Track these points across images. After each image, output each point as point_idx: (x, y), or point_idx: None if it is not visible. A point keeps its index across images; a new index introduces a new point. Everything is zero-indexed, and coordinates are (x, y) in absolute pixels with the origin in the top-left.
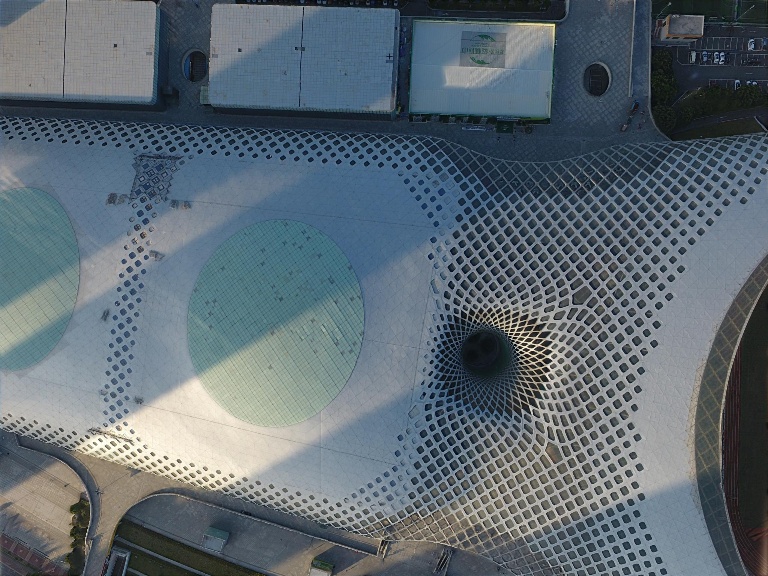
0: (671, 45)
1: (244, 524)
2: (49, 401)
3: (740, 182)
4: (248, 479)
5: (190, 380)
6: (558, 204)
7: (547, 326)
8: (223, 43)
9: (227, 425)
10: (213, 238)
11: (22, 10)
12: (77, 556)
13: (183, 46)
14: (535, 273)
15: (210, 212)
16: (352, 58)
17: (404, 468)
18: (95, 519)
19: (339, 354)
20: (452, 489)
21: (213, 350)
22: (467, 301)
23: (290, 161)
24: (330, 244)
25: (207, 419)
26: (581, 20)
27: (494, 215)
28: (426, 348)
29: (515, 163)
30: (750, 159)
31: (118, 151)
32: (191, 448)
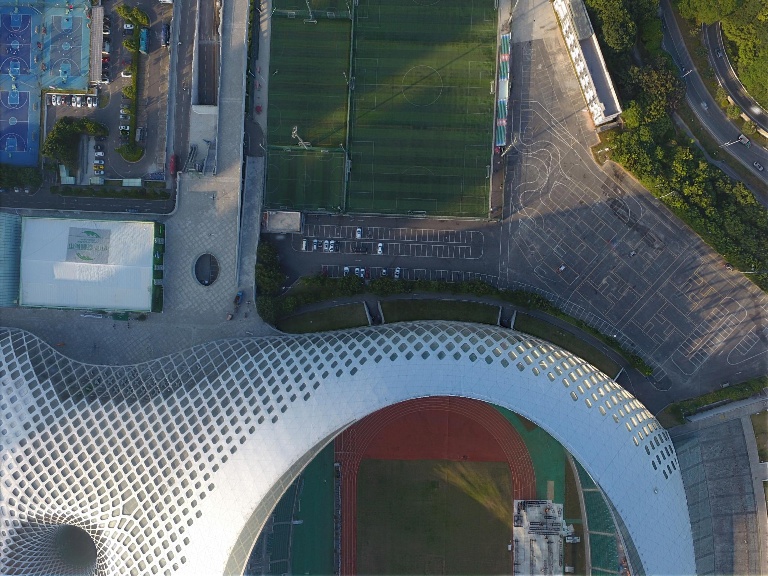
0: (286, 232)
1: None
2: None
3: (279, 398)
4: None
5: None
6: (121, 413)
7: (104, 533)
8: None
9: None
10: None
11: None
12: None
13: None
14: (92, 482)
15: None
16: None
17: None
18: None
19: None
20: None
21: None
22: (31, 507)
23: None
24: None
25: None
26: (190, 213)
27: (61, 423)
28: None
29: (93, 367)
30: (298, 371)
31: None
32: None
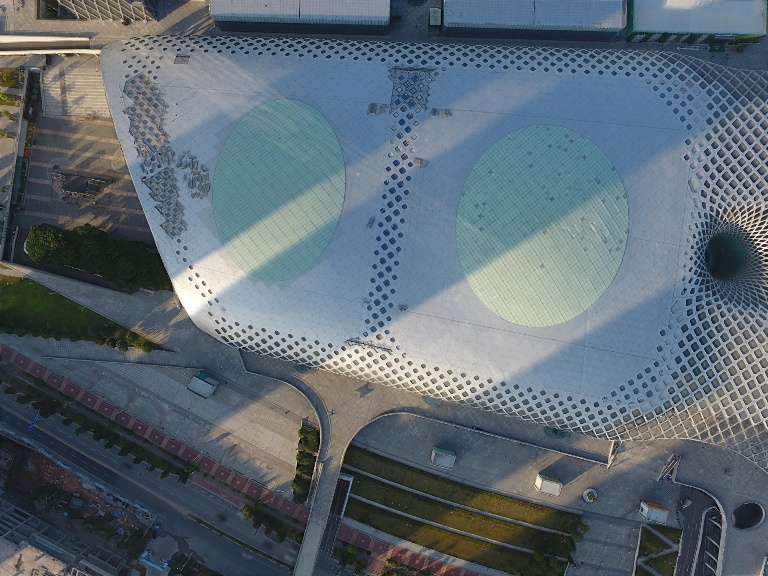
0: None
1: (468, 443)
2: (309, 312)
3: None
4: (506, 383)
5: (457, 284)
6: None
7: None
8: None
9: (492, 328)
10: (477, 144)
11: None
12: (303, 482)
13: None
14: None
15: (471, 120)
16: None
17: (665, 363)
18: (324, 442)
19: (607, 252)
20: (711, 382)
21: (484, 252)
22: (722, 199)
23: (541, 72)
24: (593, 147)
25: (472, 323)
26: None
27: (741, 118)
28: (686, 245)
29: (751, 72)
30: None
31: (371, 64)
32: (452, 354)
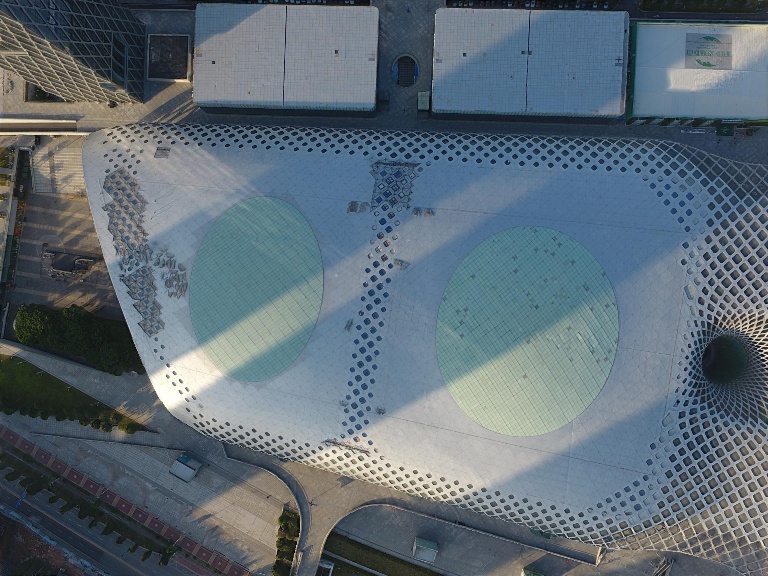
0: None
1: (451, 534)
2: (286, 412)
3: None
4: (487, 489)
5: (437, 390)
6: None
7: None
8: (447, 48)
9: (473, 435)
10: (460, 246)
11: (241, 17)
12: (283, 568)
13: (393, 51)
14: None
15: (454, 219)
16: (580, 62)
17: (655, 477)
18: (304, 531)
19: (594, 362)
20: (704, 498)
21: (464, 359)
22: (721, 307)
23: (530, 167)
24: (582, 250)
25: (452, 429)
26: None
27: (745, 219)
28: (680, 355)
29: (758, 166)
30: None
31: (353, 158)
32: (431, 459)
